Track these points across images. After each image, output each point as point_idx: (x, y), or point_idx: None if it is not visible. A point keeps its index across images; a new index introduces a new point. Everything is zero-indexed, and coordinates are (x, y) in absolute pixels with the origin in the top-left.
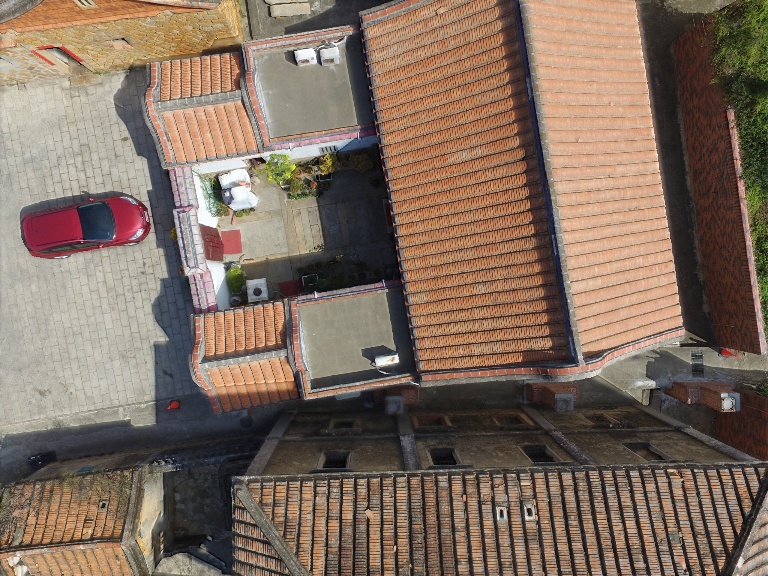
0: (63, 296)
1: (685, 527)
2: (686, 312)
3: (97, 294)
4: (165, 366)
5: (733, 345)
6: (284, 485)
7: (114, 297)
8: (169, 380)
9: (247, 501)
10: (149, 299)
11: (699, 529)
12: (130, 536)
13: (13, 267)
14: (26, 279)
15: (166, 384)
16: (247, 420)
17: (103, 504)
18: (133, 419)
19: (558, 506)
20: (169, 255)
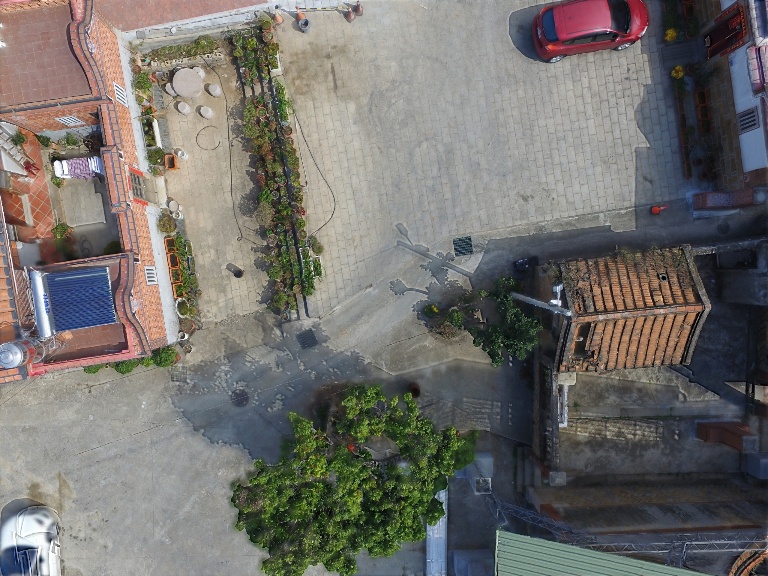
0: (548, 102)
1: None
2: None
3: (581, 100)
4: (645, 172)
5: None
6: None
7: (598, 103)
8: (648, 186)
9: None
10: (632, 105)
11: None
12: None
13: (500, 72)
14: (513, 84)
15: (645, 190)
16: (724, 226)
17: (662, 277)
18: (613, 225)
19: None
20: (653, 61)
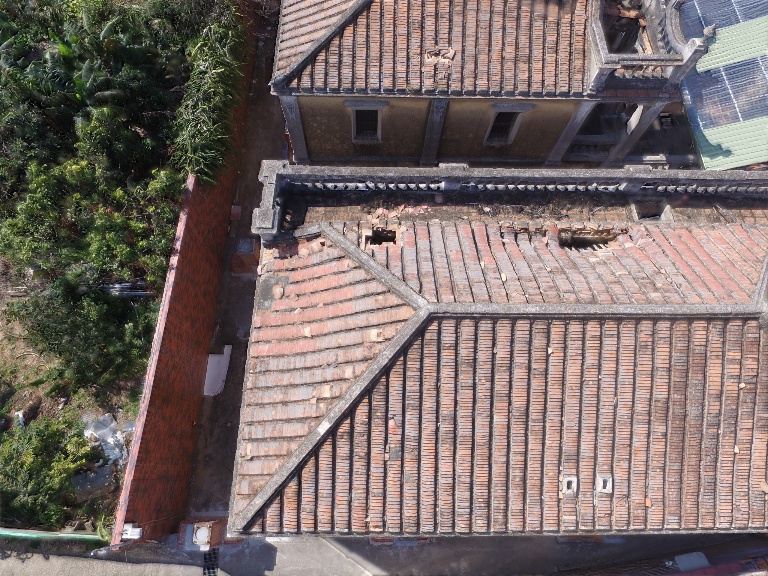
0: None
1: (378, 465)
2: None
3: None
4: None
5: None
6: None
7: None
8: None
9: None
10: None
11: (361, 462)
12: None
13: None
14: None
15: None
16: None
17: None
18: None
19: (533, 491)
20: None
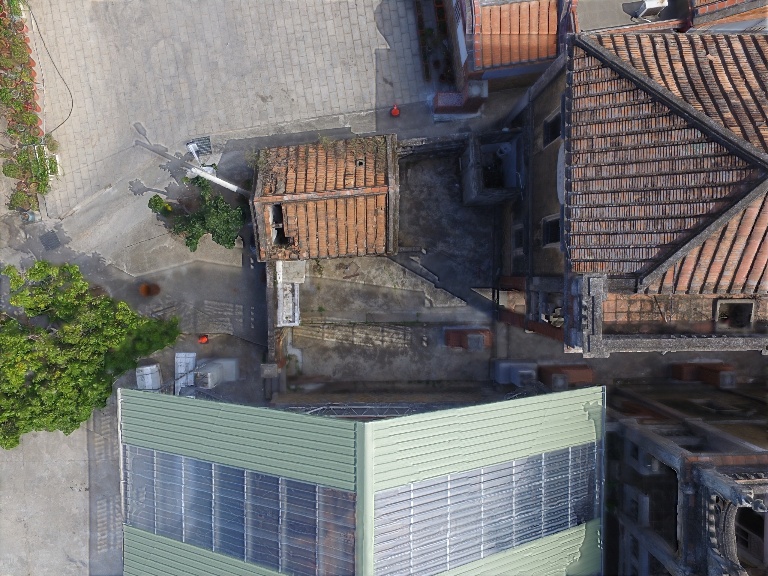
0: (287, 2)
1: None
2: None
3: (320, 0)
4: (385, 74)
5: None
6: (622, 36)
7: (337, 4)
8: (389, 89)
9: (594, 41)
10: (371, 6)
11: None
12: (395, 184)
13: None
14: None
15: (386, 92)
16: (465, 130)
17: (360, 163)
18: (353, 127)
19: None
20: None
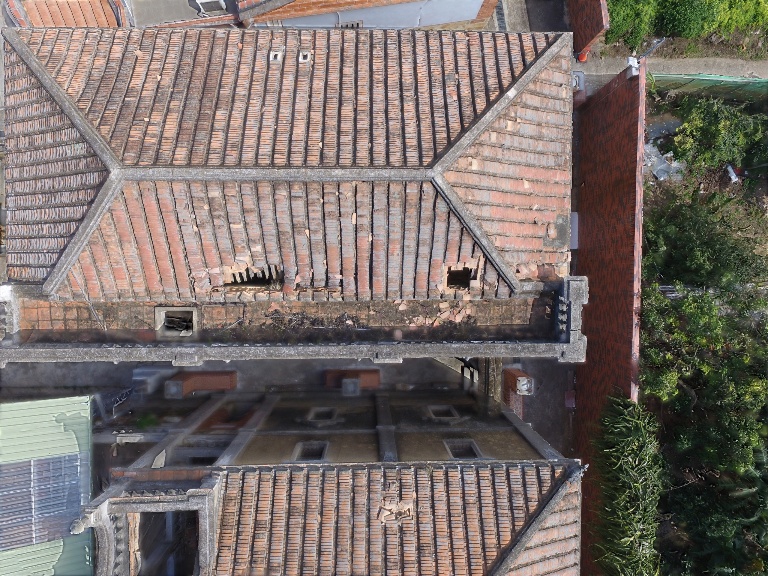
0: None
1: (463, 72)
2: (547, 23)
3: None
4: None
5: (586, 40)
6: (55, 31)
7: None
8: None
9: (11, 35)
10: None
11: (477, 73)
12: None
13: None
14: None
15: None
16: None
17: None
18: None
19: (336, 54)
20: None
